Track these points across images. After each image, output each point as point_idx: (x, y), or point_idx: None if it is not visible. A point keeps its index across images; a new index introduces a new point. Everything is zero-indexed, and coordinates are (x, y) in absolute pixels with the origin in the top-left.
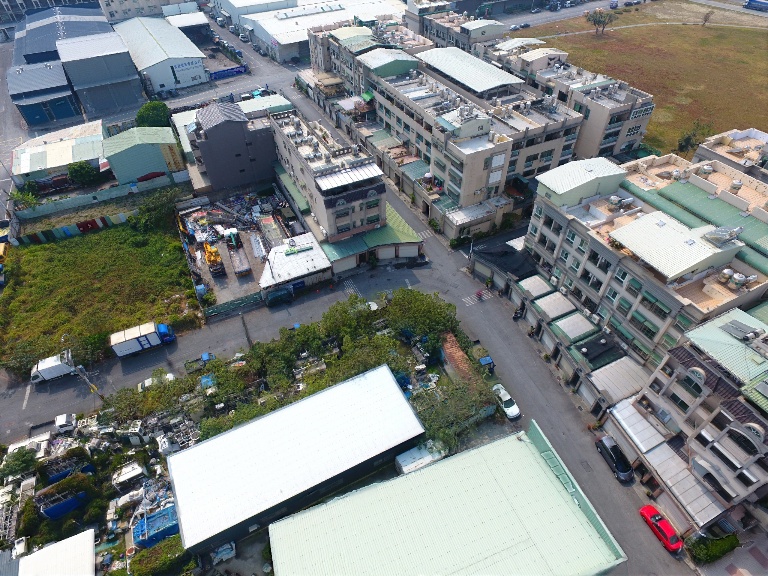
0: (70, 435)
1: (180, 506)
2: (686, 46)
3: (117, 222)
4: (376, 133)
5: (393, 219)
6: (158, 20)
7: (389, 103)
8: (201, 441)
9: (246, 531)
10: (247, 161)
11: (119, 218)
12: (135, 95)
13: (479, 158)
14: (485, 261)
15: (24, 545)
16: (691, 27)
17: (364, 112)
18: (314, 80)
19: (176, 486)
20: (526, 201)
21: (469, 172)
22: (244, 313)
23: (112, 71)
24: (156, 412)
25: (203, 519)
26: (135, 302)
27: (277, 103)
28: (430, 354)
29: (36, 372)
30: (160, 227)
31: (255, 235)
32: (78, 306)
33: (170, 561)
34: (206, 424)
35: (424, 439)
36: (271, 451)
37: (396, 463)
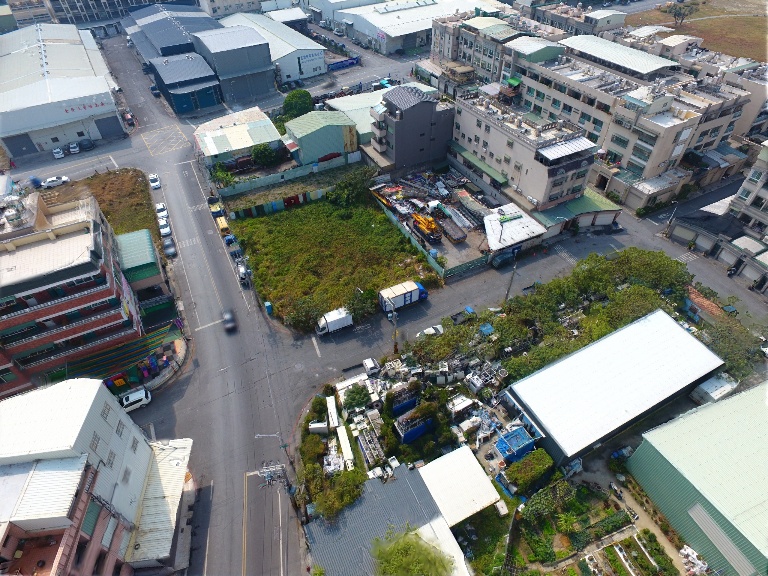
0: (376, 377)
1: (545, 424)
2: (767, 36)
3: (314, 198)
4: (525, 116)
5: (585, 190)
6: (258, 15)
7: (545, 86)
8: (509, 378)
9: (591, 448)
10: (428, 140)
11: (317, 194)
12: (267, 85)
13: (673, 131)
14: (690, 225)
15: (398, 462)
16: (763, 18)
17: (512, 96)
18: (437, 69)
19: (532, 408)
20: (701, 173)
21: (662, 145)
22: (476, 274)
23: (252, 62)
24: (448, 356)
25: (571, 433)
26: (372, 266)
27: (423, 89)
28: (677, 304)
29: (324, 324)
30: (359, 202)
31: (450, 208)
32: (321, 270)
33: (544, 471)
34: (515, 362)
35: (721, 370)
36: (599, 380)
37: (695, 392)
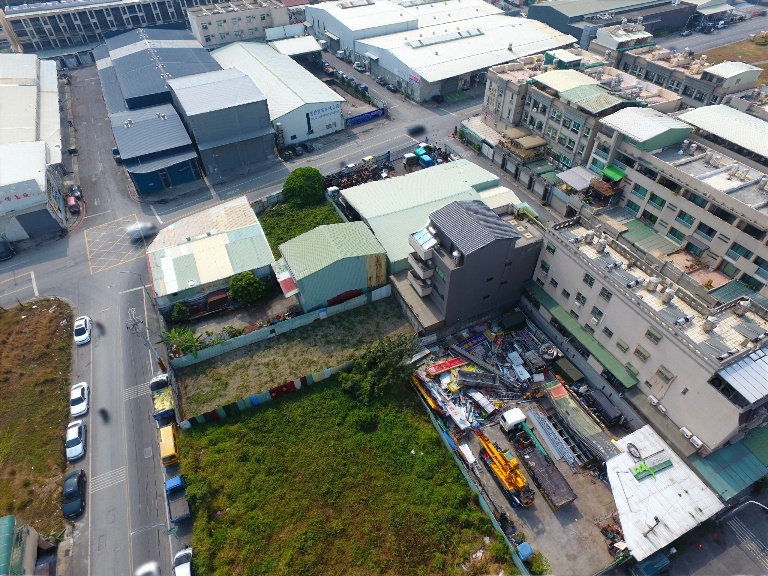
0: None
1: None
2: None
3: (319, 379)
4: (630, 226)
5: None
6: (261, 46)
7: (667, 191)
8: None
9: None
10: (496, 285)
11: (323, 374)
12: (265, 151)
13: None
14: None
15: None
16: None
17: (609, 195)
18: (490, 134)
19: None
20: None
21: None
22: None
23: (244, 124)
24: None
25: None
26: (415, 569)
27: (478, 177)
28: None
29: None
30: (389, 394)
31: (535, 411)
32: (324, 575)
33: None
34: None
35: None
36: None
37: None
